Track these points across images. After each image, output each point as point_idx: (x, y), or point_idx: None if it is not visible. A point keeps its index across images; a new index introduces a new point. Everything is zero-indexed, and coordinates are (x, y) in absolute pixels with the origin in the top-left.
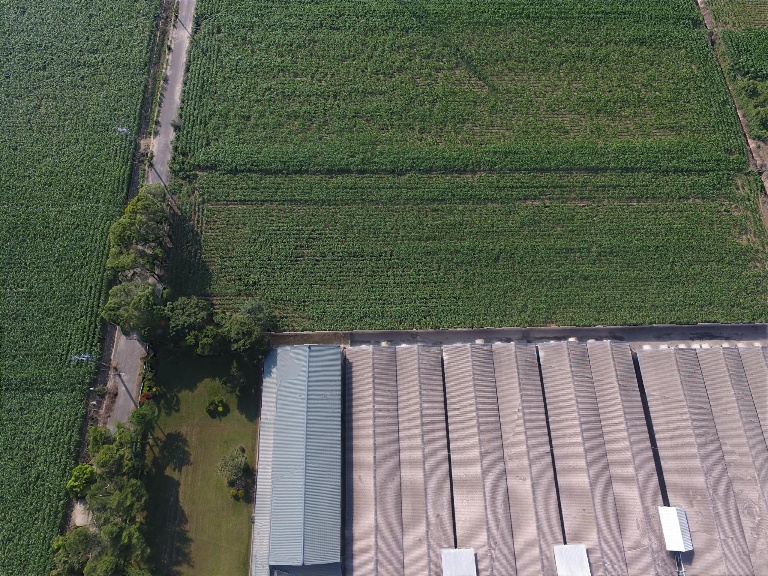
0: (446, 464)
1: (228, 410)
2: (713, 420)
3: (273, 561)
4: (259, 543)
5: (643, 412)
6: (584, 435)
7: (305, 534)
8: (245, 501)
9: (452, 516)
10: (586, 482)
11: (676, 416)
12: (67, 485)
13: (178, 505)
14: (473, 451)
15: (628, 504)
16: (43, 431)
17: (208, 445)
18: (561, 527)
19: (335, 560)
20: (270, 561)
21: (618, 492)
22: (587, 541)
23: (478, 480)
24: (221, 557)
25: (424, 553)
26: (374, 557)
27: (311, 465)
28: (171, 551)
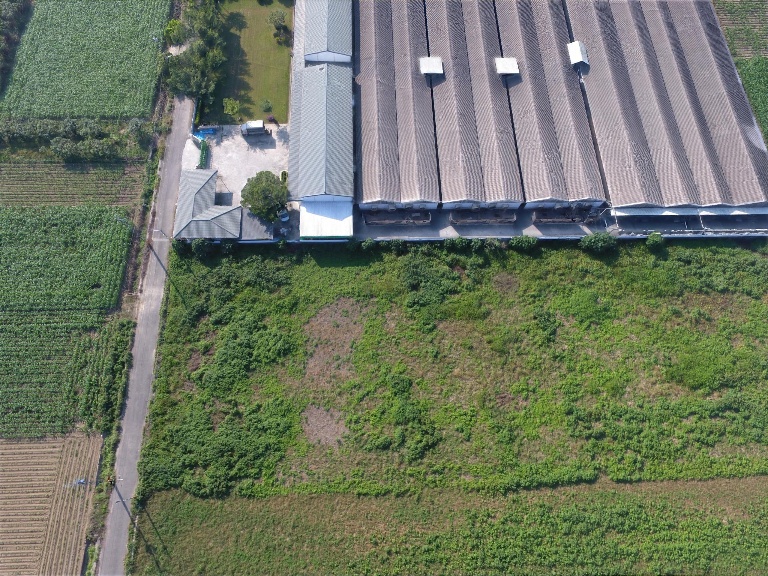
0: (423, 23)
1: (272, 2)
2: (610, 8)
3: (307, 53)
4: (297, 54)
5: (561, 3)
6: (519, 8)
7: (329, 37)
8: (286, 46)
9: (427, 48)
10: (519, 30)
11: (583, 1)
12: (165, 29)
13: (240, 47)
14: (442, 14)
15: (547, 45)
16: (145, 7)
17: (259, 19)
18: (501, 55)
19: (348, 54)
20: (305, 54)
21: (541, 39)
22: (518, 59)
23: (445, 27)
24: (271, 72)
25: (408, 60)
26: (374, 59)
27: (332, 7)
28: (237, 69)
